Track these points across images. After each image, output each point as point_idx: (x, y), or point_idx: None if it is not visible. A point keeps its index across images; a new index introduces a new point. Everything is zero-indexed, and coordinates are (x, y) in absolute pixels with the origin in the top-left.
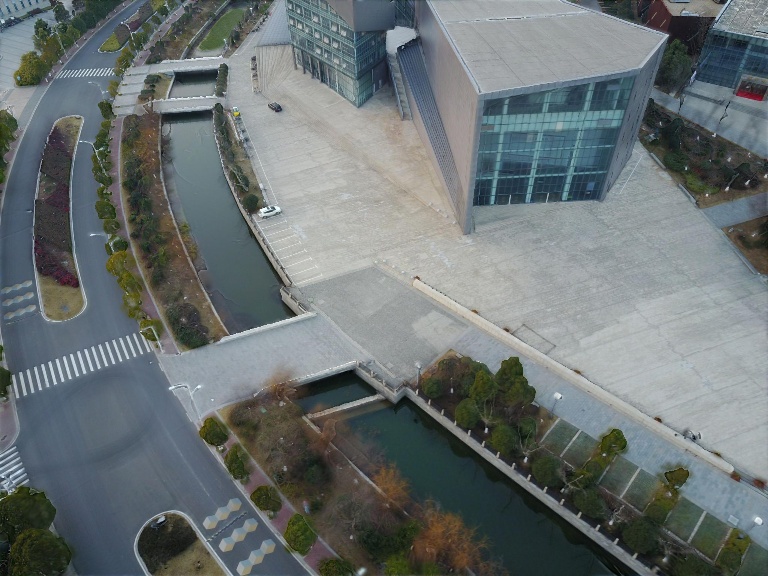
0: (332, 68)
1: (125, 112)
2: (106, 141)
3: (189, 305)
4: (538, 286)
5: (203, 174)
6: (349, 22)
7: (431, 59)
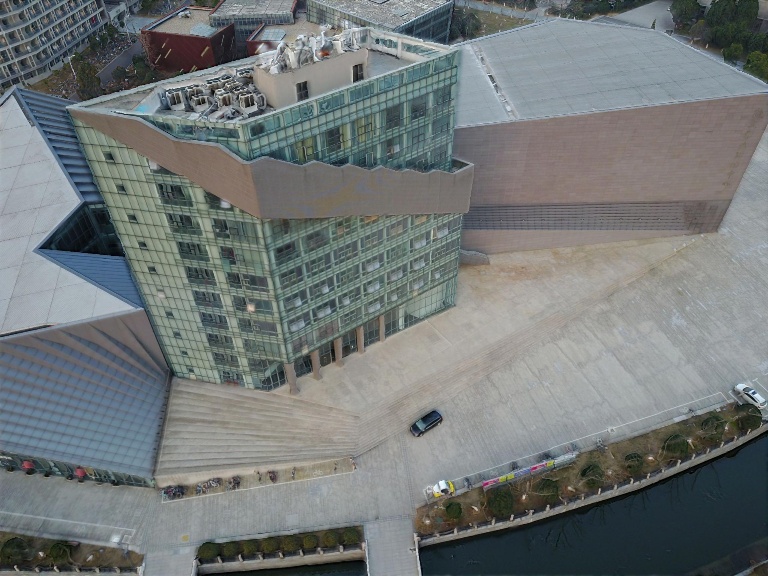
0: (401, 305)
1: None
2: None
3: None
4: (766, 200)
5: None
6: (464, 206)
7: None
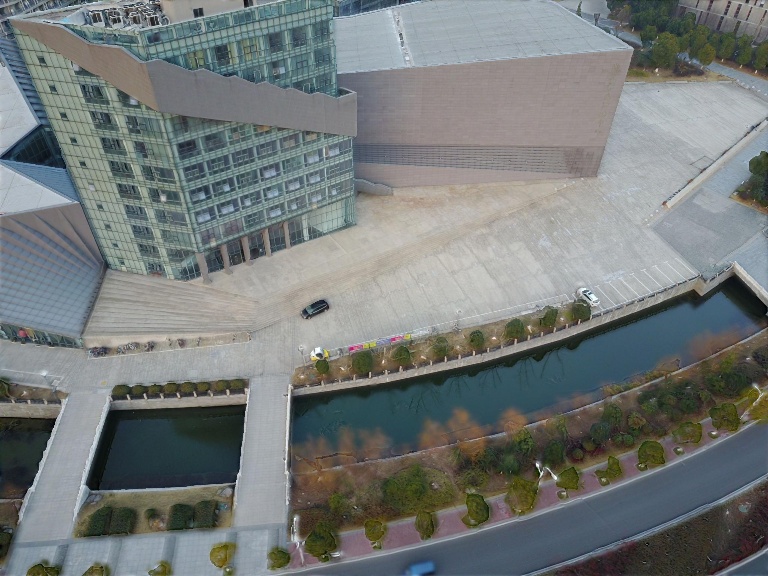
0: (302, 215)
1: (262, 546)
2: (431, 519)
3: (757, 354)
4: (647, 154)
5: (406, 433)
6: (351, 130)
7: (374, 120)
